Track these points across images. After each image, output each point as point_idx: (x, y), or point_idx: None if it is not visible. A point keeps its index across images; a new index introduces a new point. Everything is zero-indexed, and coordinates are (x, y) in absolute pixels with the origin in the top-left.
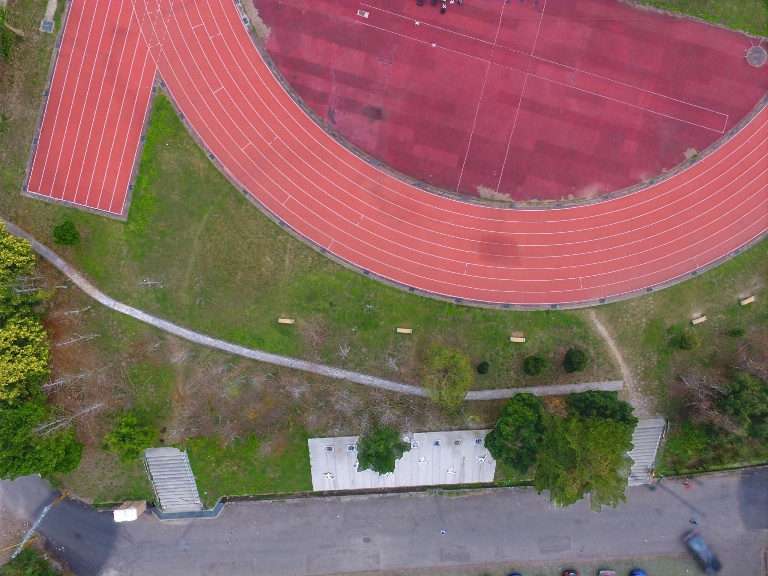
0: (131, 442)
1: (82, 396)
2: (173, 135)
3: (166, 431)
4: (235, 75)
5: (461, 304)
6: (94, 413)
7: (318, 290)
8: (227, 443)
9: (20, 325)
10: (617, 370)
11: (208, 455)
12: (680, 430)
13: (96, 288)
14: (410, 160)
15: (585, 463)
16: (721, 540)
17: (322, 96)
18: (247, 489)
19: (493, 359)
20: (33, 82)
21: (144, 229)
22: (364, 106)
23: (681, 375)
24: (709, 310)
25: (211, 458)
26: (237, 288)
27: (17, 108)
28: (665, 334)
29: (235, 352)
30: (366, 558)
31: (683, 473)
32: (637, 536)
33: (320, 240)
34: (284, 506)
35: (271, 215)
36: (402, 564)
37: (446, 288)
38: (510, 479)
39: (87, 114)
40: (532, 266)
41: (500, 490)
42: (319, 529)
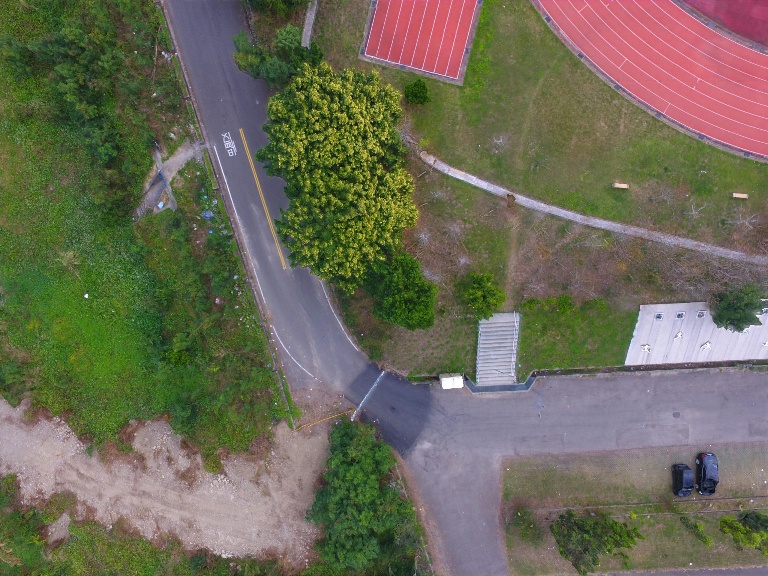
0: (493, 297)
1: None
2: None
3: None
4: None
5: None
6: None
7: (653, 155)
8: None
9: None
10: None
11: (537, 323)
12: None
13: None
14: (749, 22)
15: None
16: None
17: None
18: (560, 362)
19: None
20: None
21: (480, 93)
22: None
23: None
24: None
25: (538, 326)
26: (571, 153)
27: None
28: None
29: (568, 218)
30: (675, 433)
31: None
32: None
33: (656, 104)
34: (595, 380)
35: (606, 79)
36: (711, 439)
37: None
38: None
39: None
40: None
41: None
42: (629, 403)
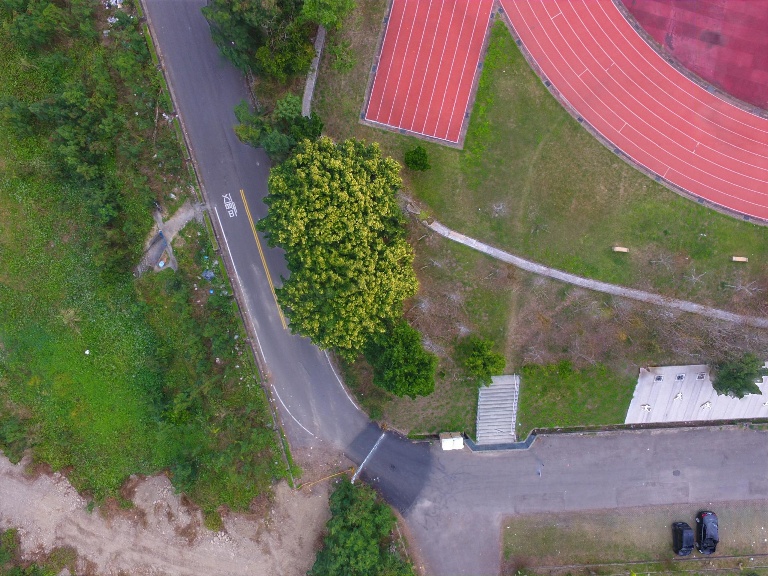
0: (493, 365)
1: (416, 325)
2: (510, 62)
3: None
4: (573, 0)
5: None
6: None
7: (652, 218)
8: None
9: None
10: None
11: (537, 384)
12: None
13: (431, 217)
14: (748, 86)
15: None
16: None
17: (660, 21)
18: (561, 421)
19: None
20: (373, 9)
21: (480, 157)
22: (702, 31)
23: None
24: None
25: (538, 388)
26: (571, 217)
27: (356, 35)
28: None
29: (568, 281)
30: (675, 491)
31: None
32: None
33: (656, 168)
34: (595, 439)
35: (606, 143)
36: (711, 497)
37: None
38: None
39: (426, 41)
40: None
41: None
42: (629, 462)
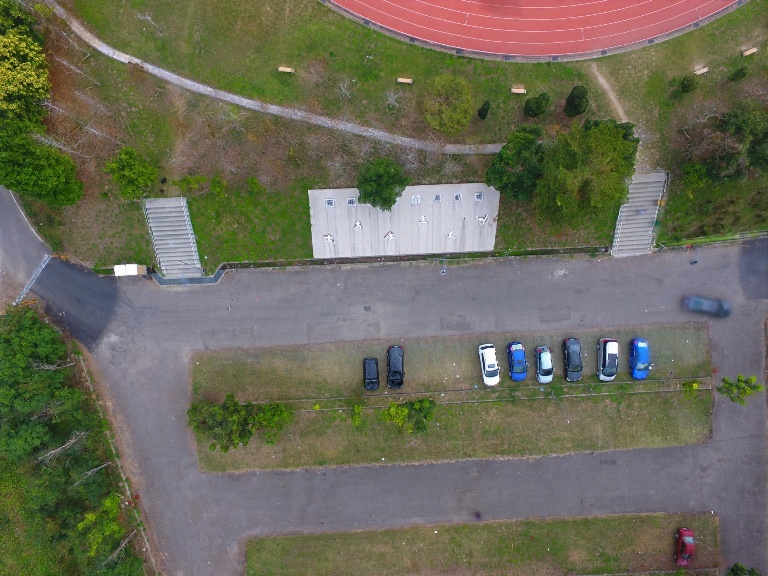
0: (131, 171)
1: (82, 146)
2: None
3: (166, 181)
4: None
5: (462, 55)
6: (94, 163)
7: (318, 40)
8: (227, 195)
9: (19, 40)
10: (618, 123)
11: (208, 209)
12: (681, 186)
13: (95, 37)
14: None
15: (586, 165)
16: (721, 310)
17: None
18: (247, 254)
19: (494, 112)
20: None
21: None
22: None
23: (682, 127)
24: (711, 62)
25: (211, 213)
26: (237, 37)
27: None
28: (667, 86)
29: (235, 102)
30: (366, 326)
31: (684, 244)
32: (637, 306)
33: None
34: (284, 273)
35: None
36: (402, 333)
37: (447, 38)
38: (510, 248)
39: None
40: (533, 17)
41: (500, 259)
42: (319, 297)
